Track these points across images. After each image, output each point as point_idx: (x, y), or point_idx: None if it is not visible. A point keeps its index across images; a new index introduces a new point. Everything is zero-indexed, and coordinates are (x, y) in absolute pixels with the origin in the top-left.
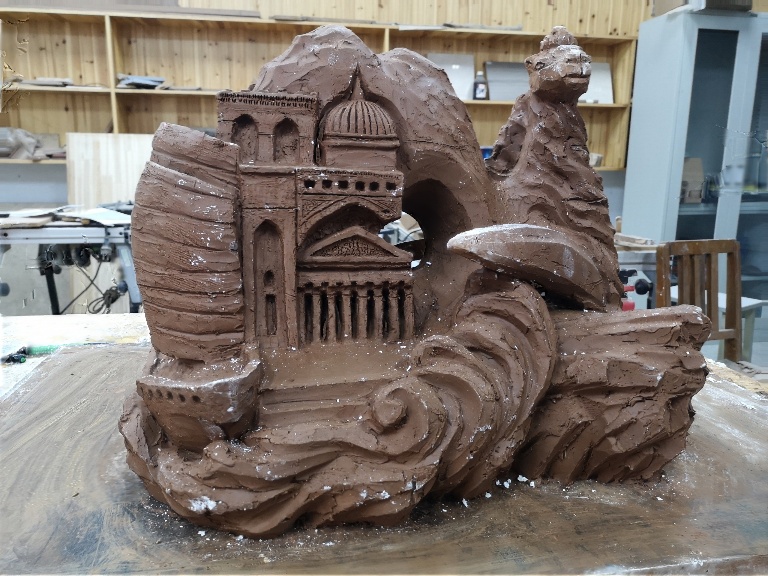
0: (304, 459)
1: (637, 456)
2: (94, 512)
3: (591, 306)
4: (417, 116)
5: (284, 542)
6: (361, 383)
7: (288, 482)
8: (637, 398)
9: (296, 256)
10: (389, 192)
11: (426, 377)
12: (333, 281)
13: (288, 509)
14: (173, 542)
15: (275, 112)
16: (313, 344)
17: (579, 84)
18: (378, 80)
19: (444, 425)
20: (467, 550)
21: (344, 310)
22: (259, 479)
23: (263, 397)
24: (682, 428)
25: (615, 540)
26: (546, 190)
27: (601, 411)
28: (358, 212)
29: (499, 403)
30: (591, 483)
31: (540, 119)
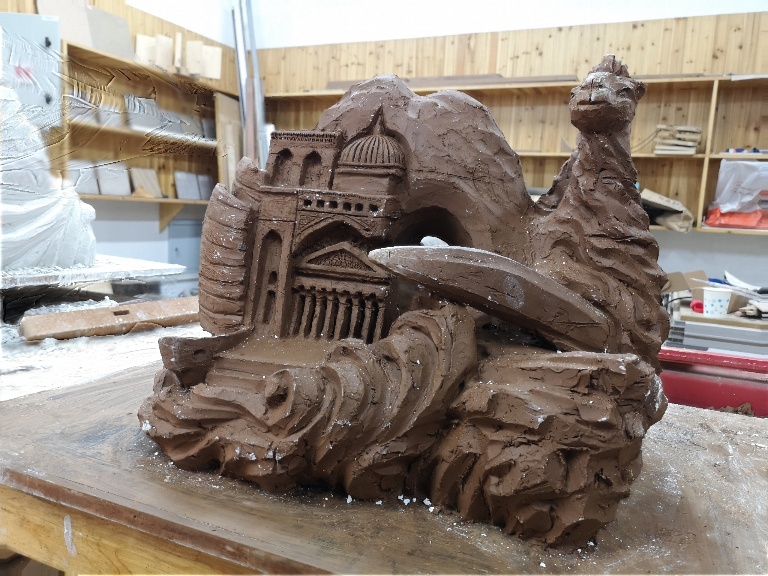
0: (206, 410)
1: (527, 509)
2: (124, 425)
3: (565, 348)
4: (426, 148)
5: (192, 475)
6: (283, 366)
7: (196, 426)
8: (521, 439)
9: (295, 262)
10: (371, 213)
11: (324, 370)
12: (319, 286)
13: (196, 449)
14: (136, 452)
15: (307, 146)
16: (297, 337)
17: (589, 111)
18: (397, 118)
19: (309, 410)
20: (298, 526)
21: (326, 313)
22: (174, 416)
23: (217, 362)
24: (579, 490)
25: (433, 571)
26: (574, 225)
27: (486, 445)
28: (351, 230)
29: (375, 407)
30: (493, 529)
31: (579, 151)
